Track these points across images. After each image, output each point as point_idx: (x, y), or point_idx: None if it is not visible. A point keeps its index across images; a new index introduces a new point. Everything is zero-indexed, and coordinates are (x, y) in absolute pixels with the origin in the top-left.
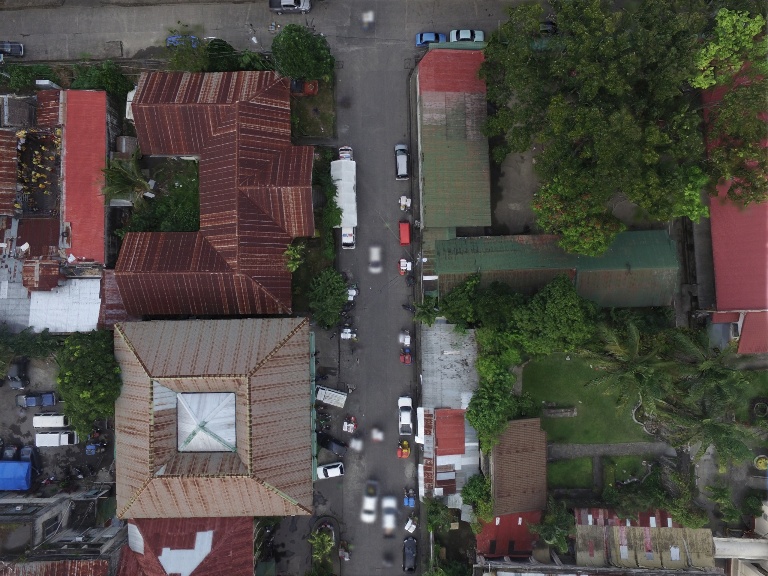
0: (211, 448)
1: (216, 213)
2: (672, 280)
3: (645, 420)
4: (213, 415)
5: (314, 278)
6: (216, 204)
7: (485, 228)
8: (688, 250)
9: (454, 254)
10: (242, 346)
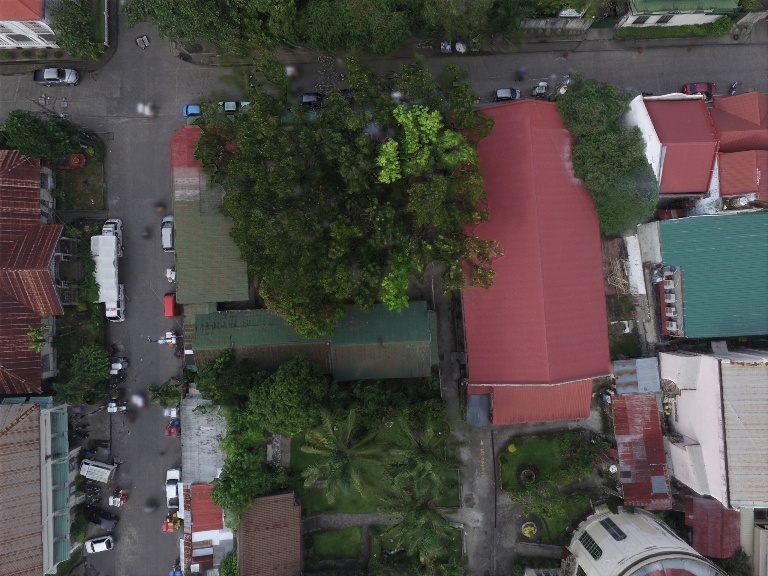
0: None
1: None
2: (426, 353)
3: None
4: None
5: (74, 354)
6: None
7: (255, 298)
8: (457, 318)
9: (211, 329)
10: None
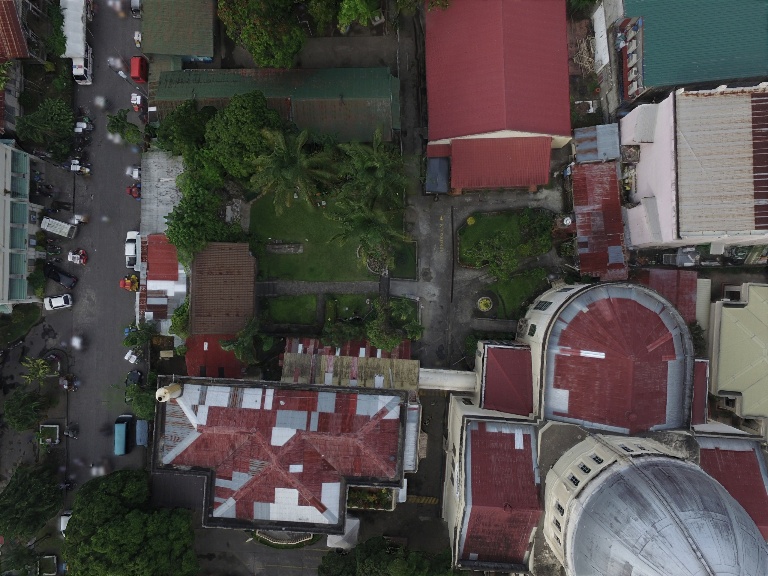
0: None
1: None
2: (387, 113)
3: (368, 258)
4: None
5: None
6: None
7: None
8: (421, 94)
9: (175, 83)
10: None
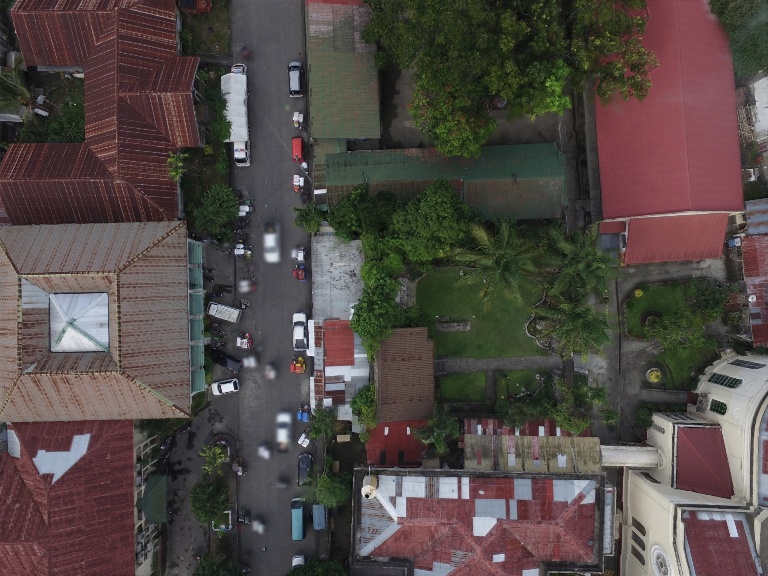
0: (83, 348)
1: (99, 122)
2: (559, 190)
3: (537, 333)
4: (83, 313)
5: (205, 192)
6: (99, 113)
7: (380, 145)
8: (582, 166)
9: (343, 166)
10: (115, 246)
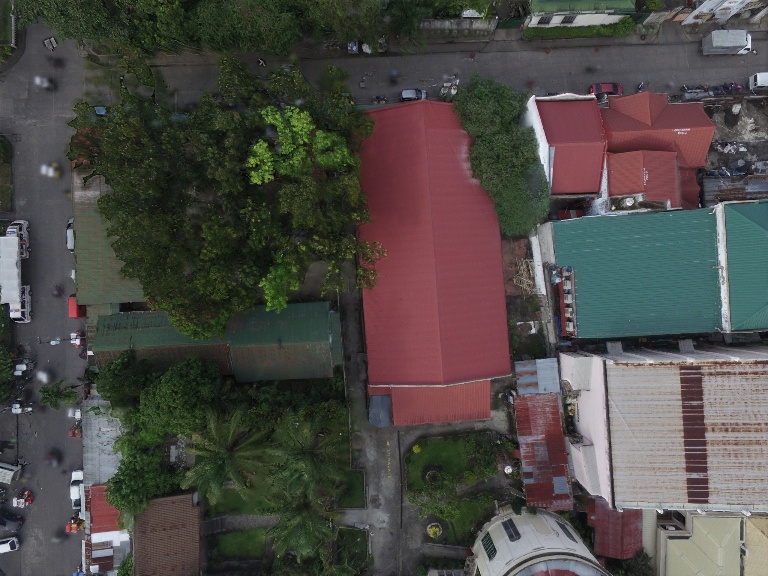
0: None
1: None
2: (327, 353)
3: None
4: None
5: None
6: None
7: None
8: None
9: (112, 330)
10: None
